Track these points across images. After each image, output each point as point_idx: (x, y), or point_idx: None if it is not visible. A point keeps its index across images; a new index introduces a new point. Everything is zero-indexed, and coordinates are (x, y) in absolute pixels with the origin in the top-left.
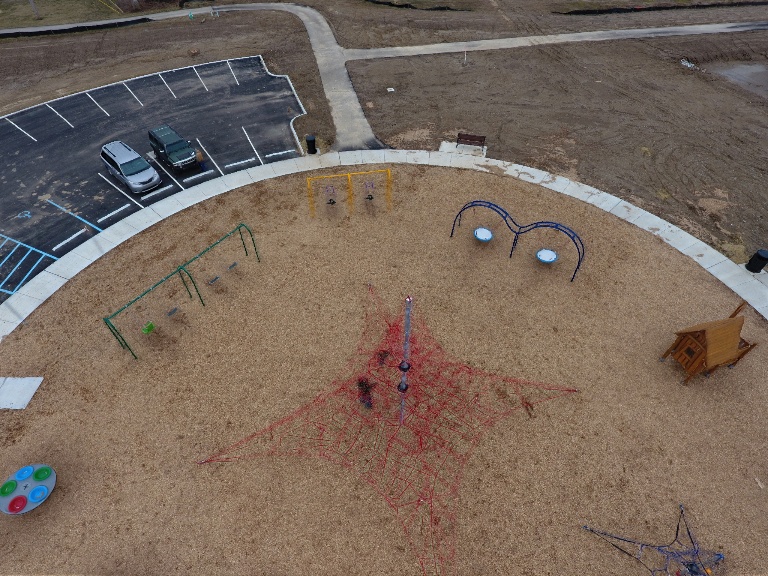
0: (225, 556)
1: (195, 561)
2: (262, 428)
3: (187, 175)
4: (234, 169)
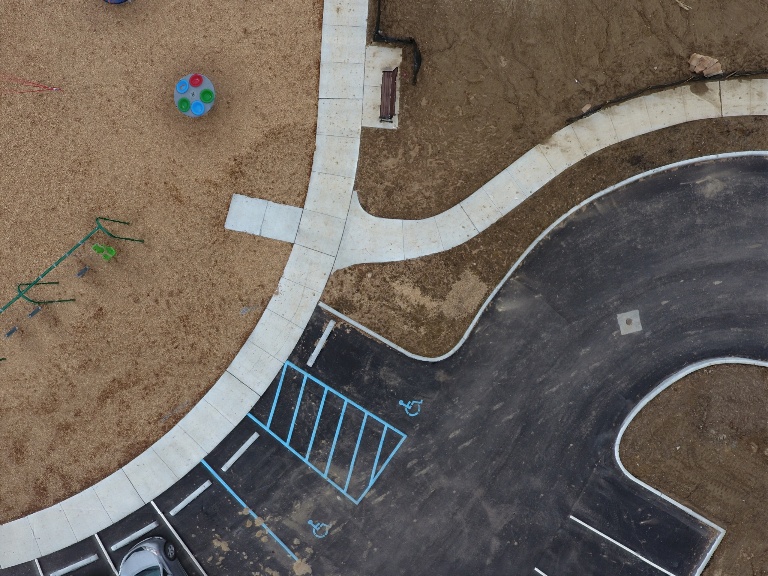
0: (36, 5)
1: (59, 7)
2: (0, 108)
3: (92, 574)
4: (19, 574)
